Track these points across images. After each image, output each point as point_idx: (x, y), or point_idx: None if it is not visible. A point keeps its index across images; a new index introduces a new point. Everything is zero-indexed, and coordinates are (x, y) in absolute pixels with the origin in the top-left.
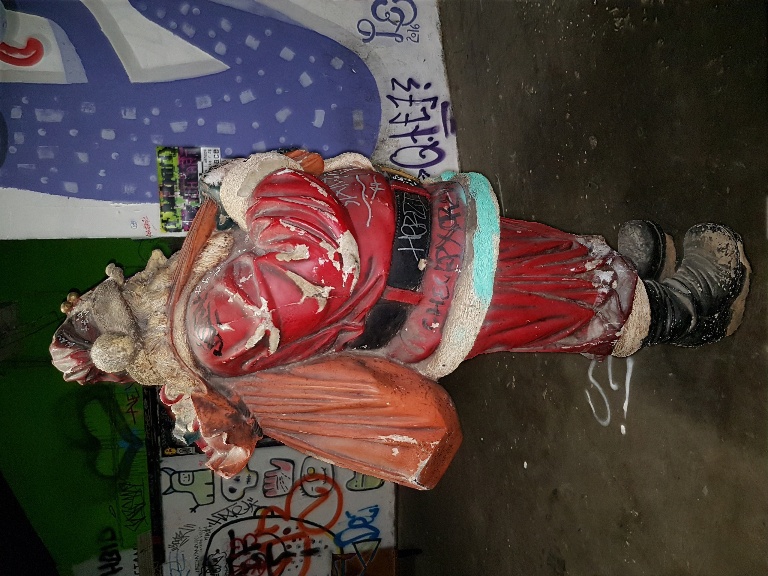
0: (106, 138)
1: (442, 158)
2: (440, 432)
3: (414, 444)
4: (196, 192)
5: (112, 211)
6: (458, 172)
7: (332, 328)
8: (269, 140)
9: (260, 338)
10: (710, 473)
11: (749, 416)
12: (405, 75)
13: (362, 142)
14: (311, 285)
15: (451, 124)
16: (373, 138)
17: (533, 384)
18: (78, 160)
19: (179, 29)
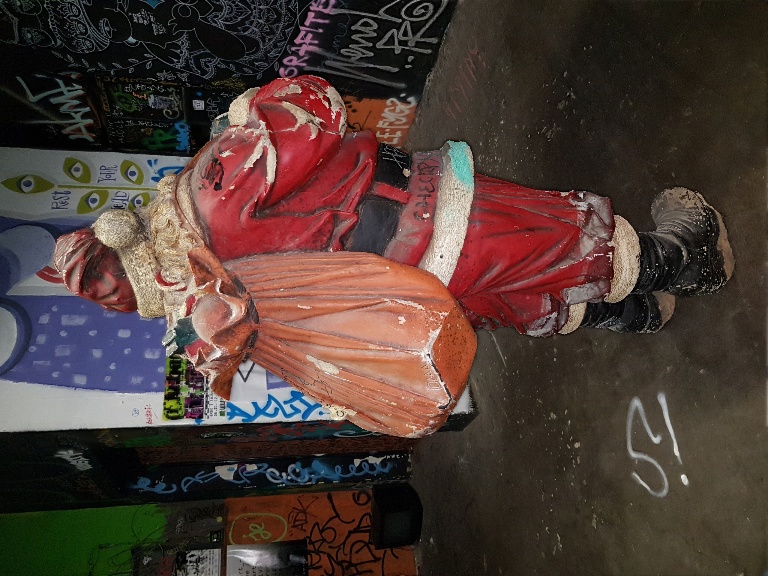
0: (122, 336)
1: None
2: (447, 304)
3: (421, 310)
4: (201, 380)
5: (116, 400)
6: None
7: (327, 211)
8: None
9: (258, 158)
10: None
11: None
12: None
13: None
14: (304, 111)
15: None
16: None
17: (579, 522)
18: (92, 357)
19: None
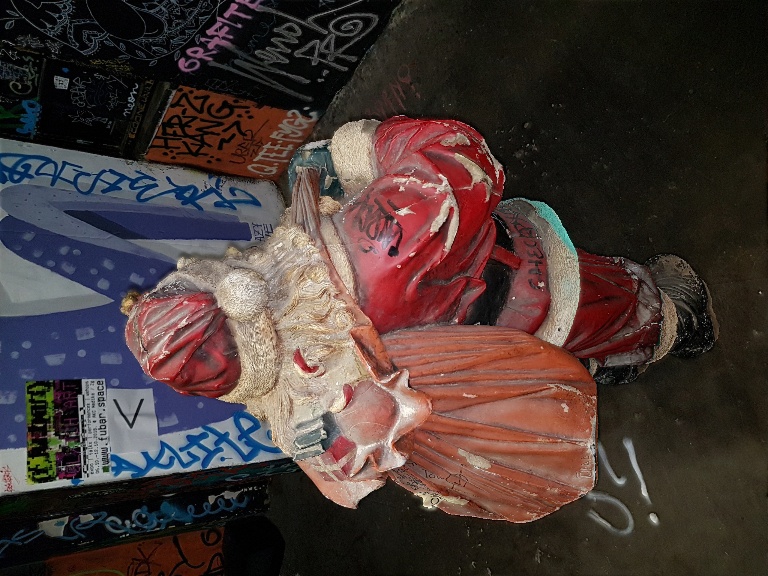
0: None
1: None
2: (592, 386)
3: (579, 395)
4: (76, 429)
5: None
6: None
7: (462, 277)
8: None
9: (444, 220)
10: None
11: None
12: None
13: None
14: (479, 168)
15: None
16: None
17: (518, 557)
18: None
19: (57, 267)
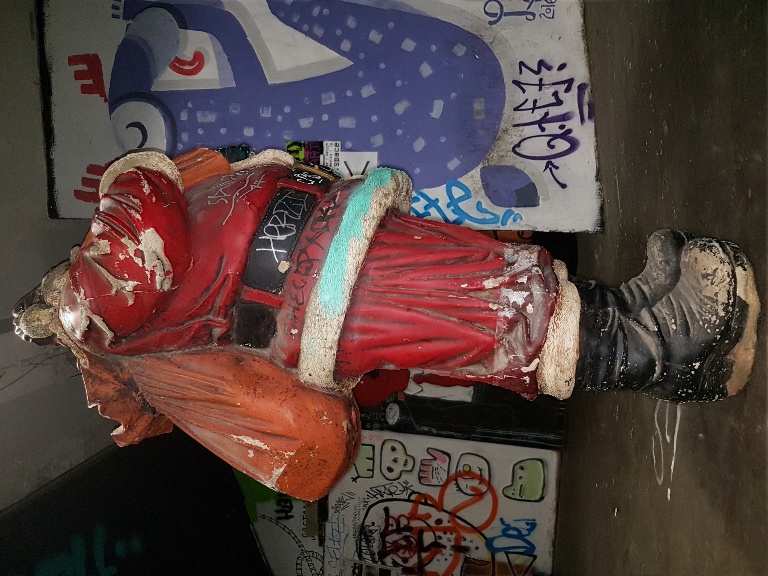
0: (247, 135)
1: (575, 148)
2: (295, 443)
3: (266, 450)
4: None
5: None
6: (595, 164)
7: (196, 322)
8: (387, 133)
9: (88, 323)
10: (717, 575)
11: (748, 511)
12: (535, 56)
13: (482, 132)
14: (114, 278)
15: (589, 109)
16: (495, 127)
17: (627, 419)
18: None
19: (310, 30)
